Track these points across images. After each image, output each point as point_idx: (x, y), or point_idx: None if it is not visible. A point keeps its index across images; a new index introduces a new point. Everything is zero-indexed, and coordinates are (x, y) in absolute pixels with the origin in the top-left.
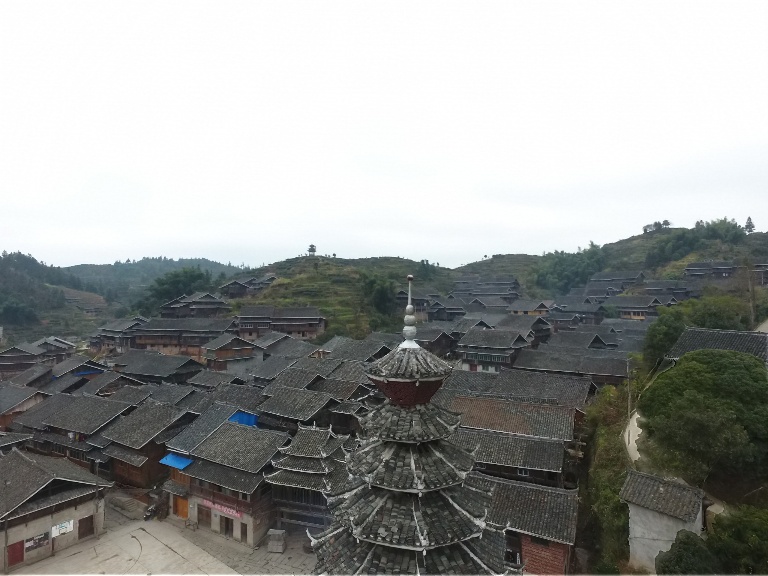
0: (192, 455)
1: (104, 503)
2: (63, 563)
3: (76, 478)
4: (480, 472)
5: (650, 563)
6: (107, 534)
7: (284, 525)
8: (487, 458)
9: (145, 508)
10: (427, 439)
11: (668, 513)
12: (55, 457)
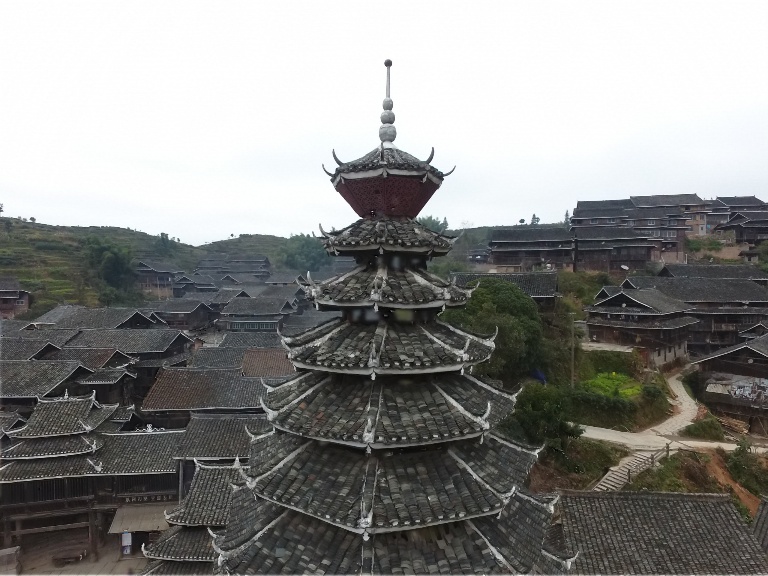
0: None
1: None
2: None
3: None
4: None
5: None
6: None
7: (13, 543)
8: None
9: None
10: (440, 246)
11: None
12: None
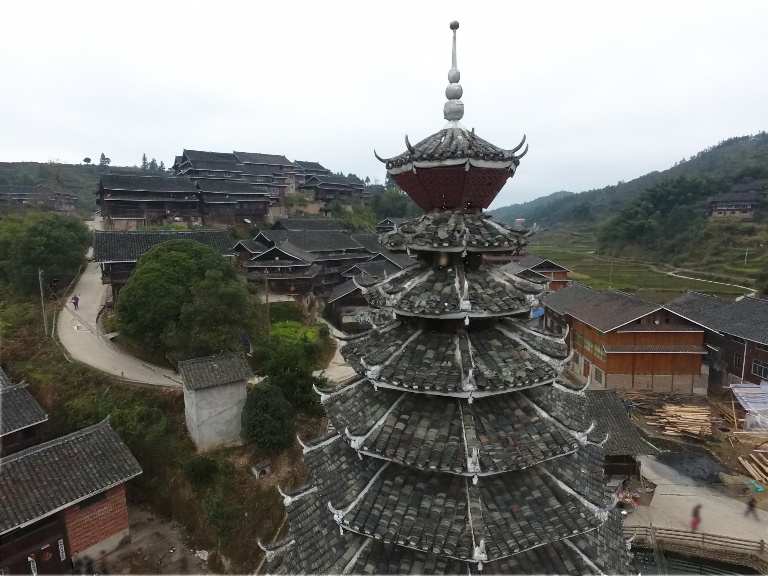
0: None
1: None
2: None
3: None
4: None
5: (218, 437)
6: None
7: None
8: None
9: None
10: None
11: (235, 380)
12: None
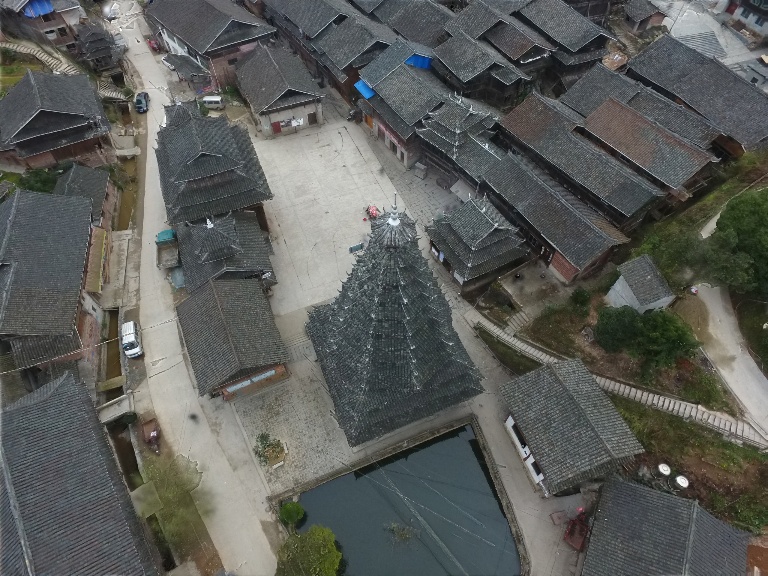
0: (374, 90)
1: (321, 105)
2: (301, 140)
3: (302, 88)
4: (559, 194)
5: (613, 304)
6: (325, 125)
7: None
8: (582, 179)
9: (349, 110)
10: None
11: (634, 293)
12: (291, 54)
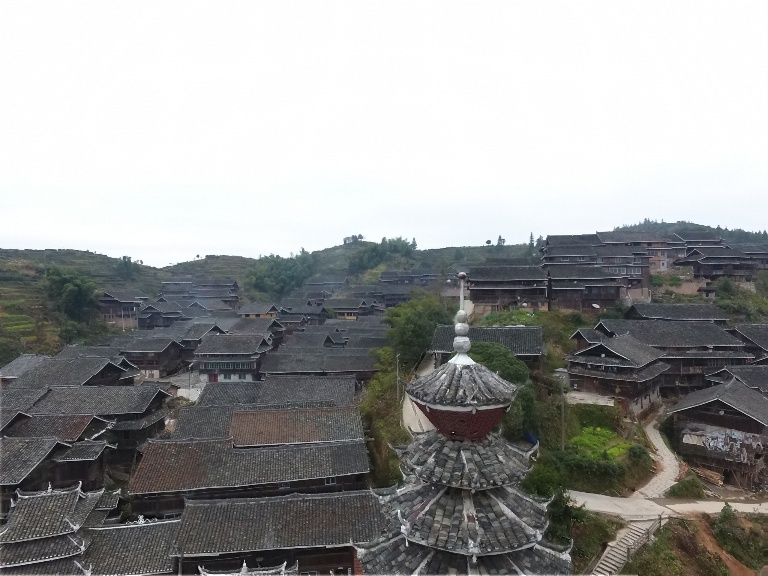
0: None
1: None
2: None
3: None
4: (299, 493)
5: None
6: None
7: None
8: (294, 475)
9: None
10: None
11: None
12: None
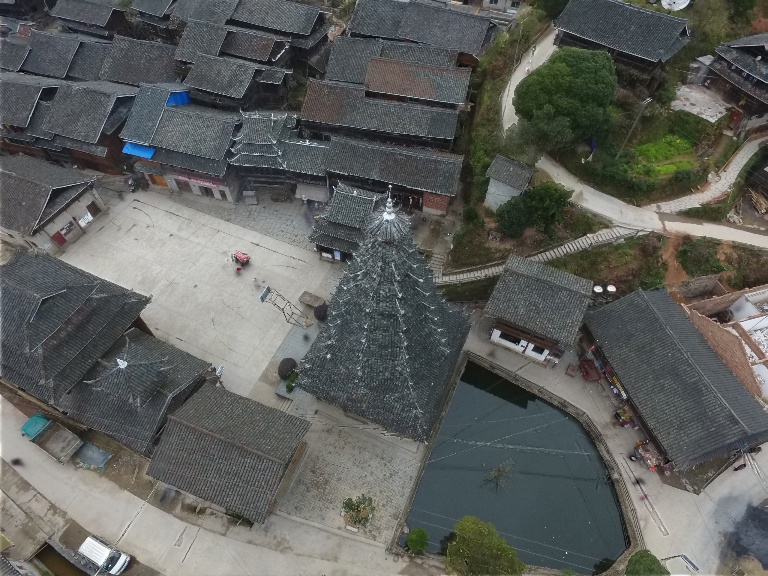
0: (152, 145)
1: (95, 190)
2: (99, 237)
3: (66, 182)
4: (398, 149)
5: (495, 205)
6: (111, 209)
7: None
8: (401, 130)
9: (124, 182)
10: None
11: (510, 185)
12: (12, 155)
